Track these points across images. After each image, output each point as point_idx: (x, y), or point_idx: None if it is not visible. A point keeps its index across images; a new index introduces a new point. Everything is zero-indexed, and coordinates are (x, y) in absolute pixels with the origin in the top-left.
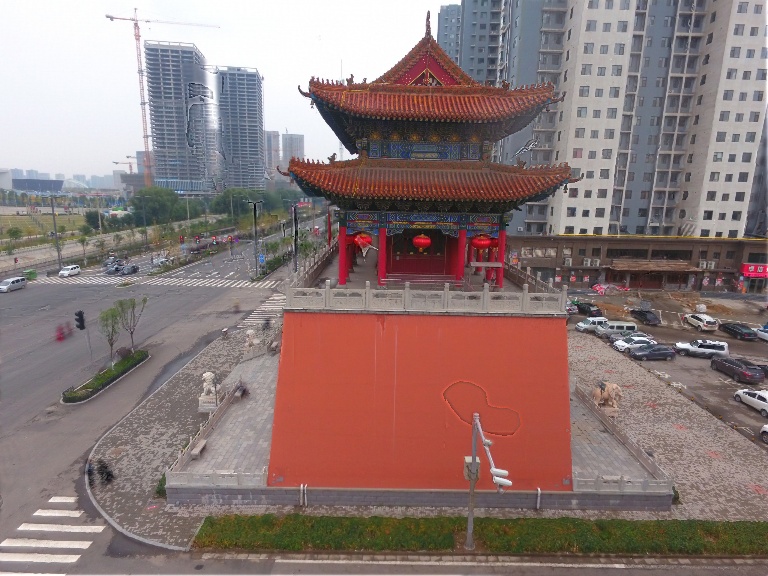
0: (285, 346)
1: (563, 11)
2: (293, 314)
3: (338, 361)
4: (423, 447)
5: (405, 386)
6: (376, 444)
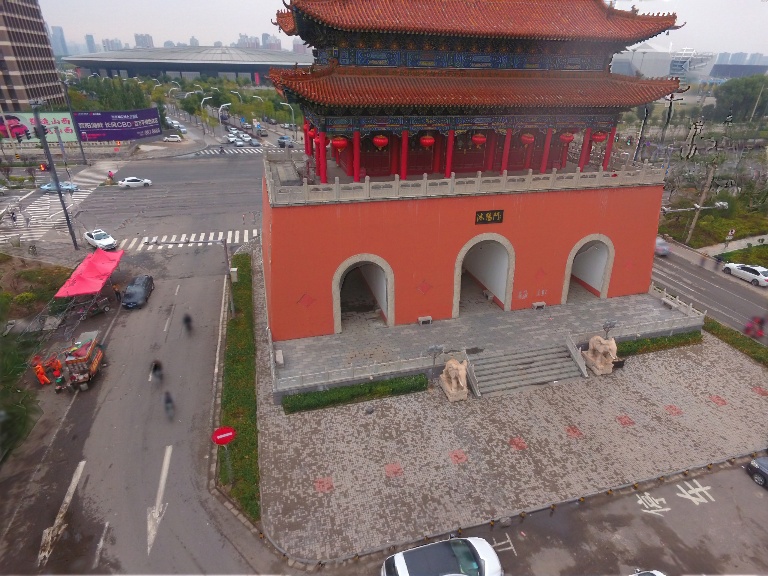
0: None
1: None
2: None
3: None
4: None
5: None
6: None
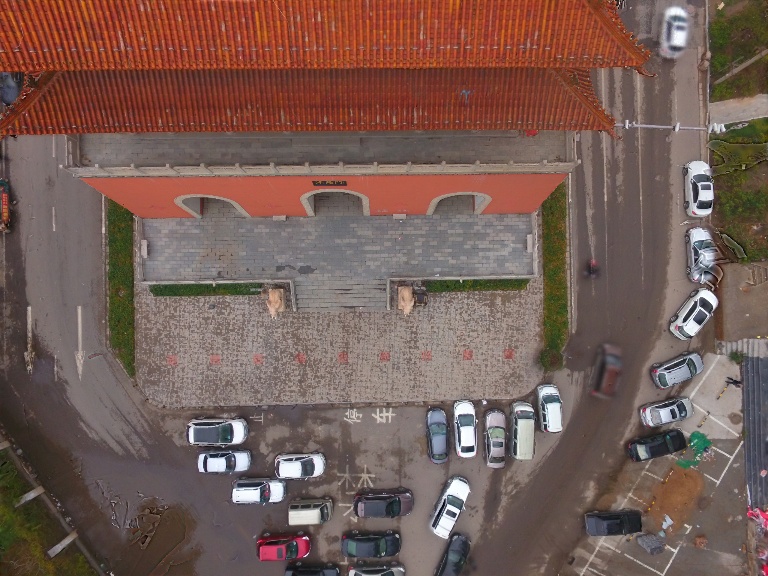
0: None
1: None
2: None
3: None
4: None
5: None
6: None
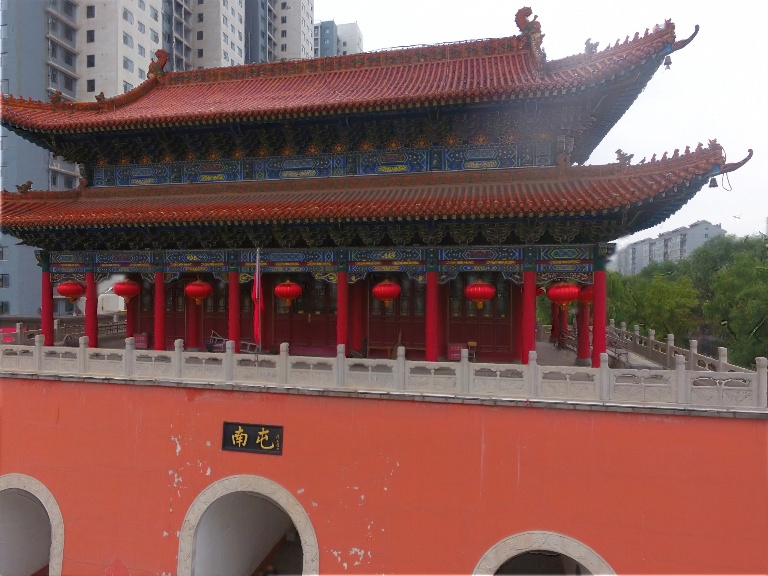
0: None
1: (72, 27)
2: None
3: None
4: None
5: None
6: None
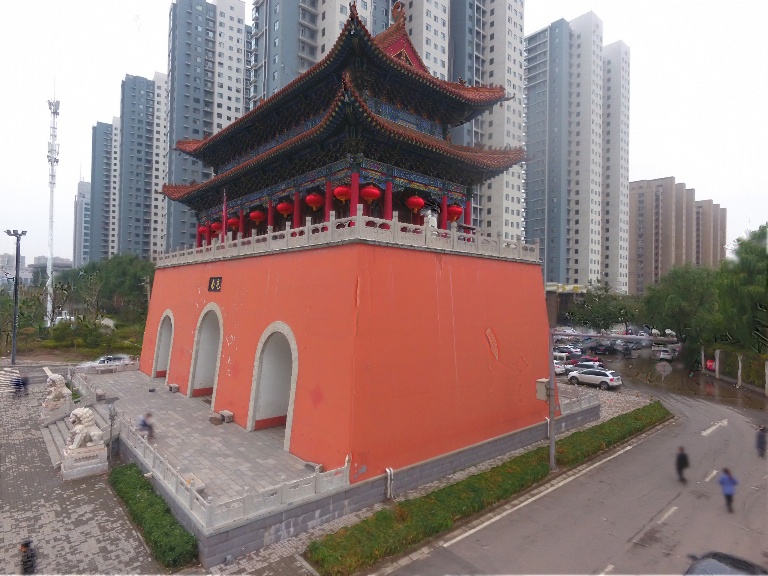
0: (362, 285)
1: None
2: (366, 247)
3: (409, 304)
4: (478, 395)
5: (461, 330)
6: (445, 399)
